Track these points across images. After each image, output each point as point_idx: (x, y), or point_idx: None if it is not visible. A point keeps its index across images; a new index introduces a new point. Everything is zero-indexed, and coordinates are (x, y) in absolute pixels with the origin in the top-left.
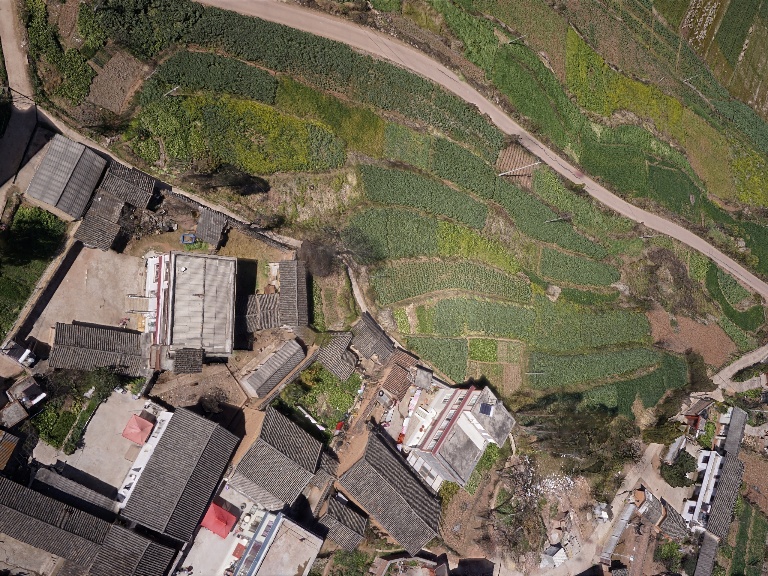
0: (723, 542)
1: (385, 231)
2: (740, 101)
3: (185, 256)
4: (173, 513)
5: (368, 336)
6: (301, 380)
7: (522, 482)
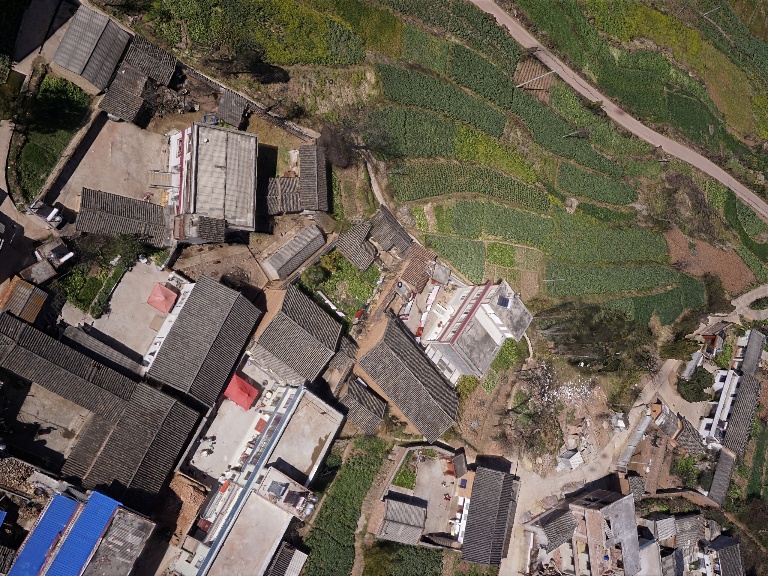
0: (740, 458)
1: (403, 130)
2: (760, 40)
3: (207, 128)
4: (197, 375)
5: (387, 228)
6: (321, 267)
7: (539, 386)
